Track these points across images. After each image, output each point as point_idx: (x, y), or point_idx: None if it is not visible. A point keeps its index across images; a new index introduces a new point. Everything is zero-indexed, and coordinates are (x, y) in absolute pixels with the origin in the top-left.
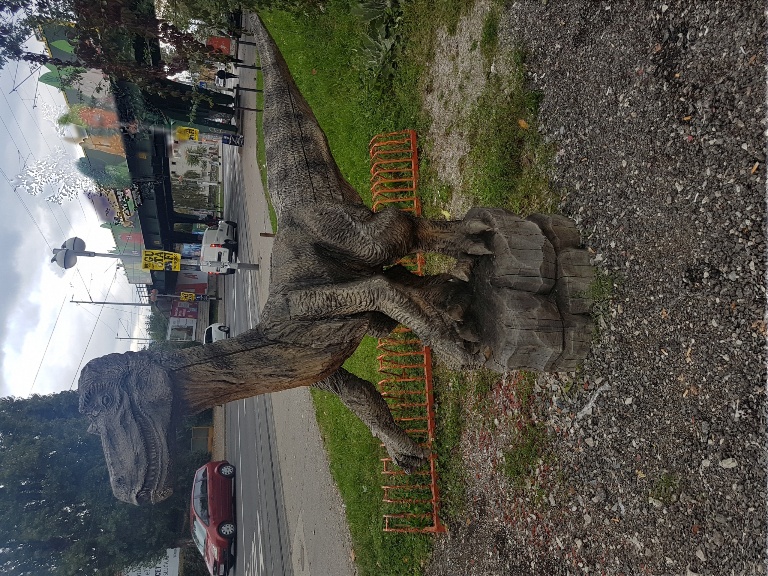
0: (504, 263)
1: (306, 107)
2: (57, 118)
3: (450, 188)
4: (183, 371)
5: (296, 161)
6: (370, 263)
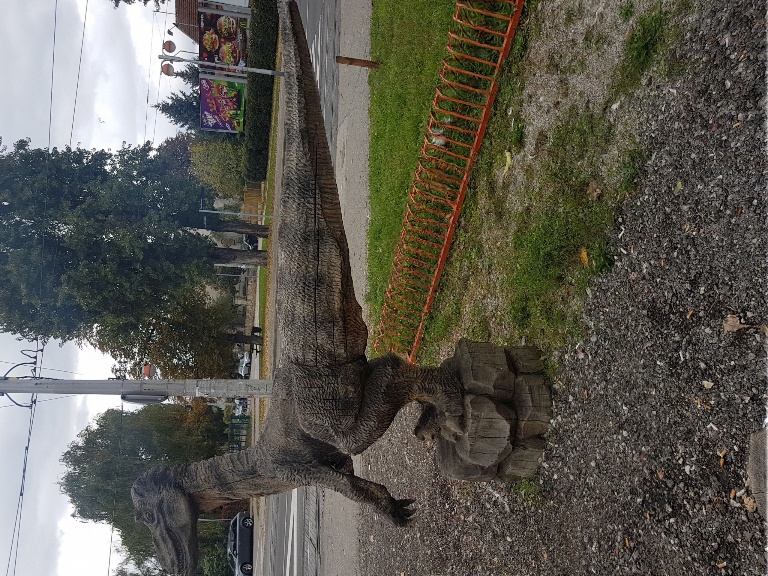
0: (462, 455)
1: (335, 194)
2: None
3: (522, 141)
4: (198, 494)
5: (305, 311)
6: None
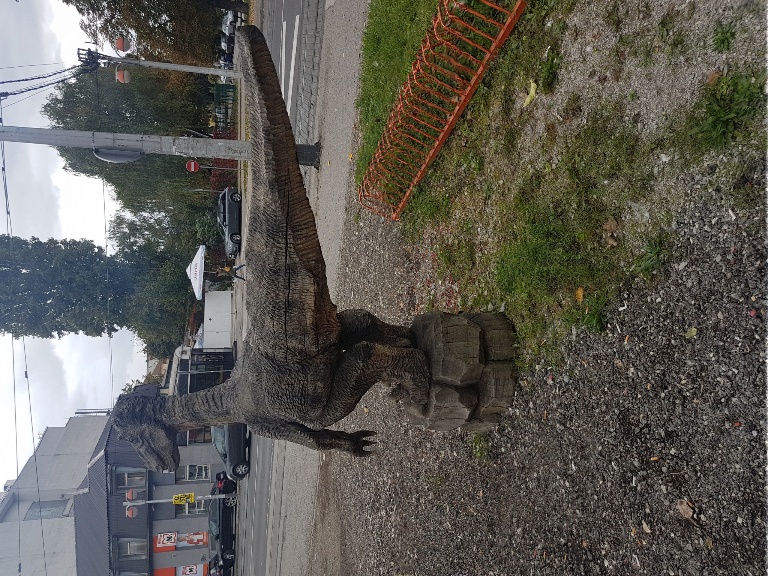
0: None
1: (310, 227)
2: None
3: (552, 85)
4: None
5: (274, 328)
6: None
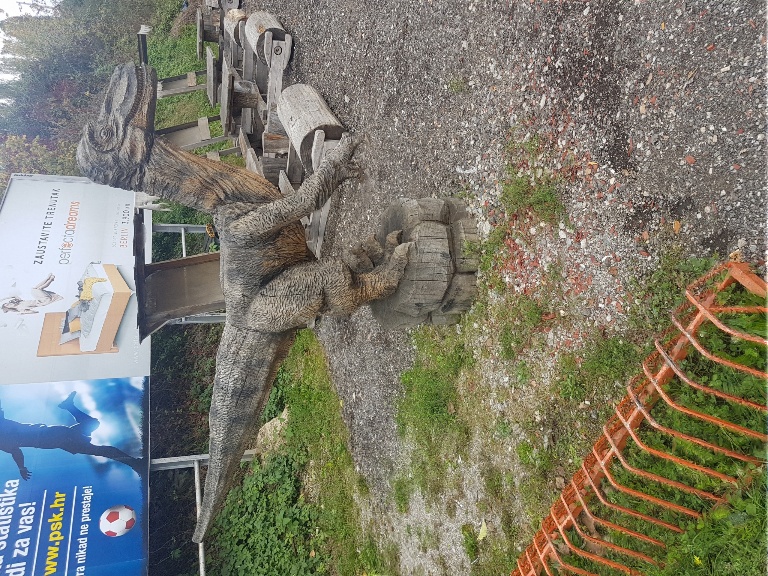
0: None
1: None
2: None
3: None
4: None
5: None
6: None
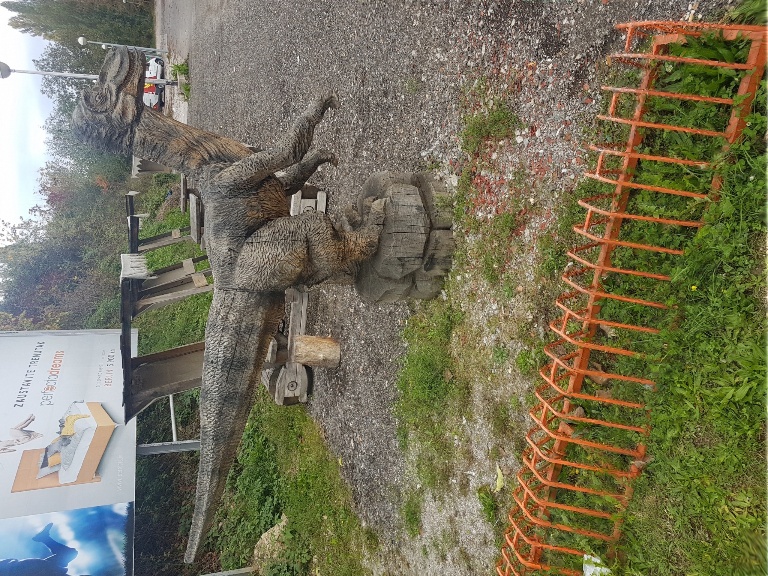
0: None
1: None
2: None
3: None
4: None
5: None
6: None
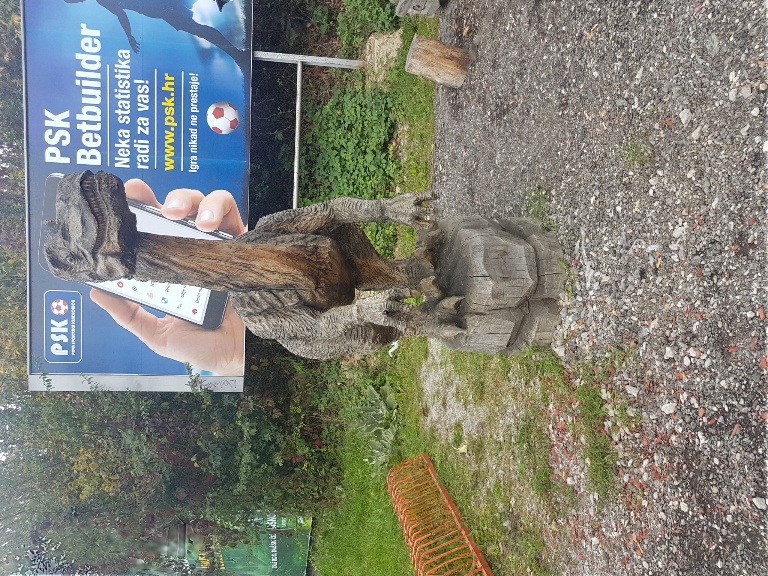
0: (449, 224)
1: None
2: (75, 505)
3: None
4: None
5: None
6: (328, 227)
